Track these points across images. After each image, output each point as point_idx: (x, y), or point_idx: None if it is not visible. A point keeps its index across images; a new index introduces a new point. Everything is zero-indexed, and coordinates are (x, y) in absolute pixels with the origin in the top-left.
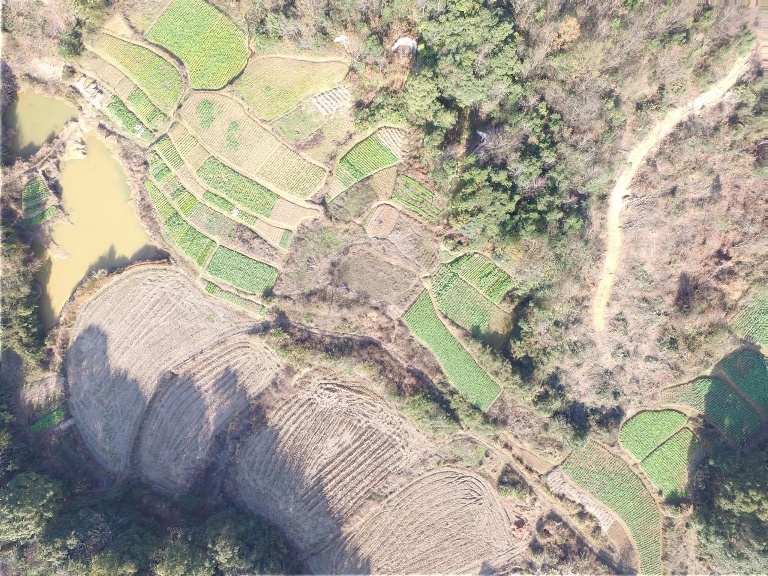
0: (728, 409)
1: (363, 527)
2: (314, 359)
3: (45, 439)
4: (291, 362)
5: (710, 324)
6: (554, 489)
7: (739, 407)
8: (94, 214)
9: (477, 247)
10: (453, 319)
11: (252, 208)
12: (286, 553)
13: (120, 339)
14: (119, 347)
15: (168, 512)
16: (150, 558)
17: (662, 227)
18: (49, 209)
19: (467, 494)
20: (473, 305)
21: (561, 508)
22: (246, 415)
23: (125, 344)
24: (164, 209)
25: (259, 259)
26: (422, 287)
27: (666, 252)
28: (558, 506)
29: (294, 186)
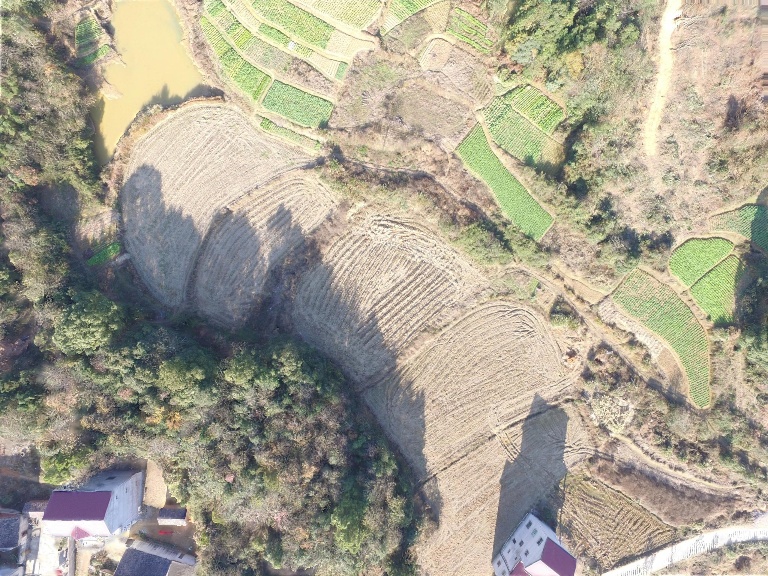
0: None
1: (417, 360)
2: (369, 192)
3: (101, 272)
4: (346, 197)
5: (758, 147)
6: (605, 318)
7: None
8: (147, 54)
9: (531, 75)
10: (507, 149)
11: (308, 39)
12: (343, 382)
13: (175, 176)
14: (174, 184)
15: (225, 344)
16: (216, 367)
17: (713, 46)
18: (102, 48)
19: (519, 327)
20: (526, 136)
21: (612, 336)
22: (301, 250)
23: (180, 181)
24: (219, 44)
25: (315, 92)
26: (475, 121)
27: (717, 72)
28: (609, 335)
29: (350, 16)
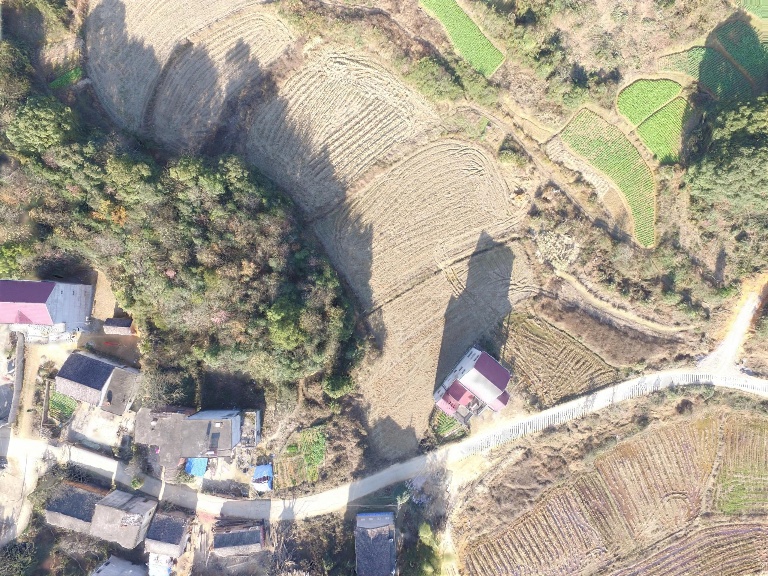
0: (721, 76)
1: (367, 194)
2: (325, 27)
3: (62, 95)
4: (303, 32)
5: None
6: (553, 156)
7: (732, 74)
8: None
9: None
10: None
11: None
12: (292, 207)
13: (138, 8)
14: (137, 15)
15: None
16: (163, 167)
17: None
18: None
19: (469, 165)
20: None
21: (559, 175)
22: (258, 81)
23: (143, 12)
24: None
25: None
26: None
27: None
28: (556, 173)
29: None
